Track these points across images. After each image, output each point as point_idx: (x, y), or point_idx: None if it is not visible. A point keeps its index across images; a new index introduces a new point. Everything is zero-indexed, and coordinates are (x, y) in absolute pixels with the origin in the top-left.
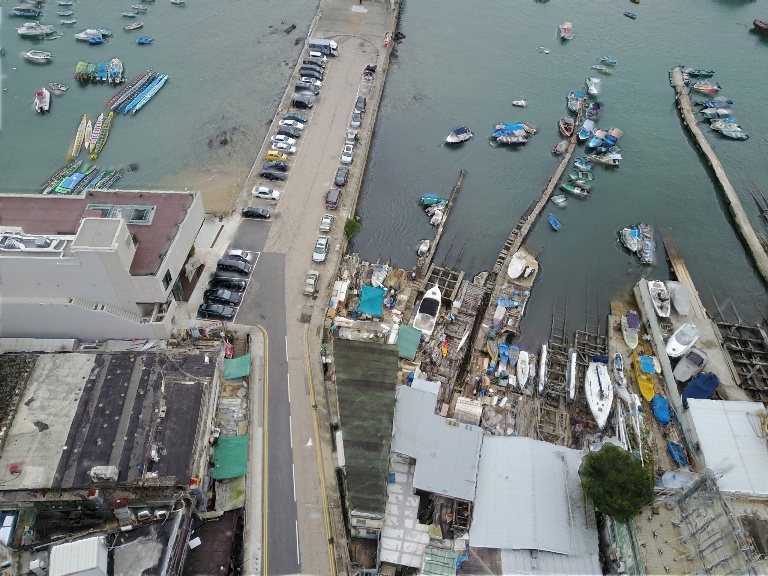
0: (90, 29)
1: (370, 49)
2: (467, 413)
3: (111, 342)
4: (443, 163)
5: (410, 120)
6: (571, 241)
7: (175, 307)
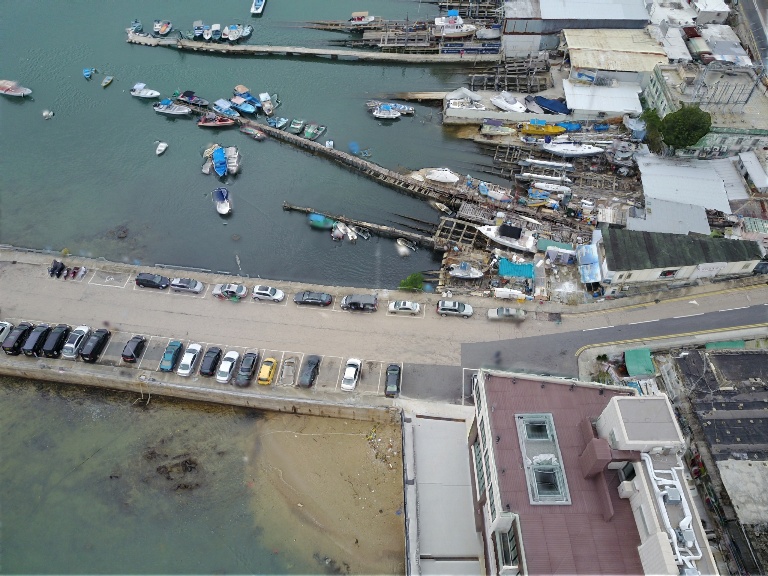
0: None
1: None
2: (615, 216)
3: None
4: (256, 226)
5: (169, 246)
6: (388, 148)
7: None
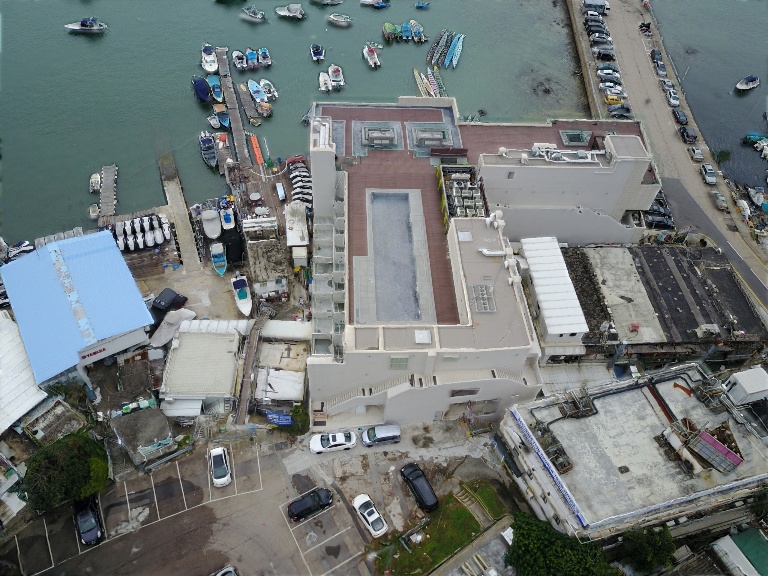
0: None
1: (632, 9)
2: None
3: (593, 246)
4: (739, 108)
5: (692, 71)
6: None
7: None
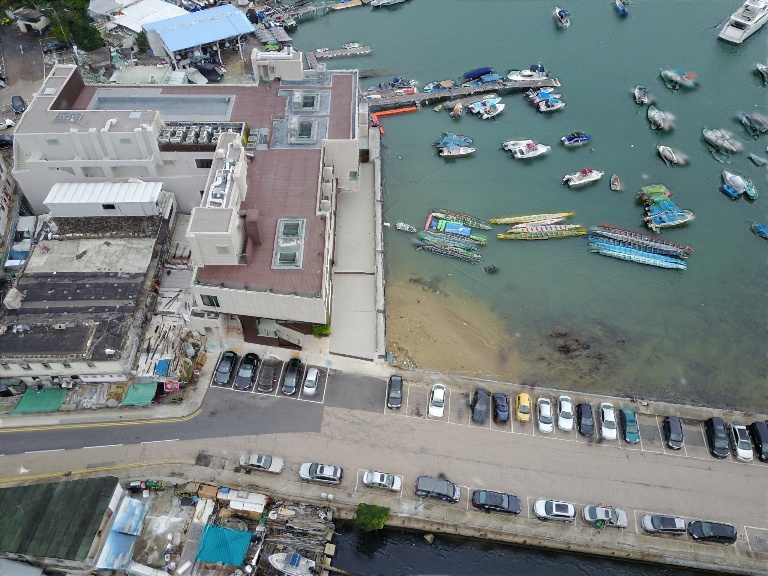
0: (745, 179)
1: None
2: None
3: None
4: None
5: None
6: None
7: (218, 326)
